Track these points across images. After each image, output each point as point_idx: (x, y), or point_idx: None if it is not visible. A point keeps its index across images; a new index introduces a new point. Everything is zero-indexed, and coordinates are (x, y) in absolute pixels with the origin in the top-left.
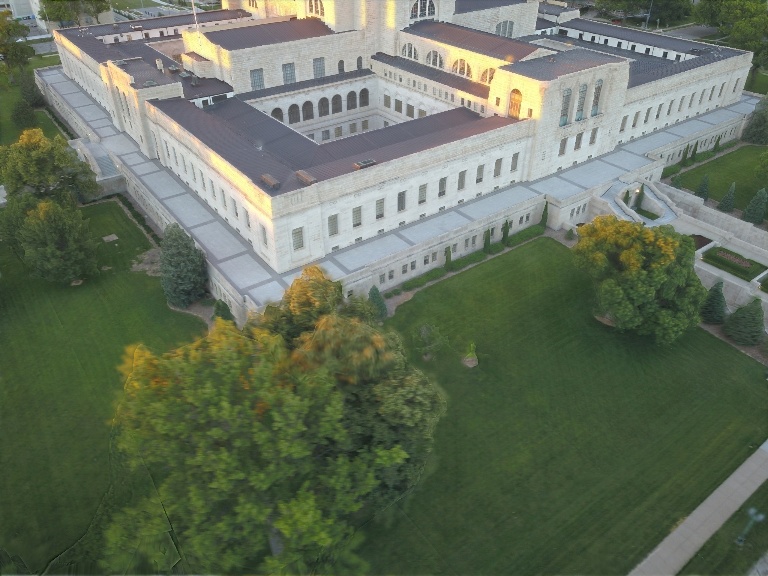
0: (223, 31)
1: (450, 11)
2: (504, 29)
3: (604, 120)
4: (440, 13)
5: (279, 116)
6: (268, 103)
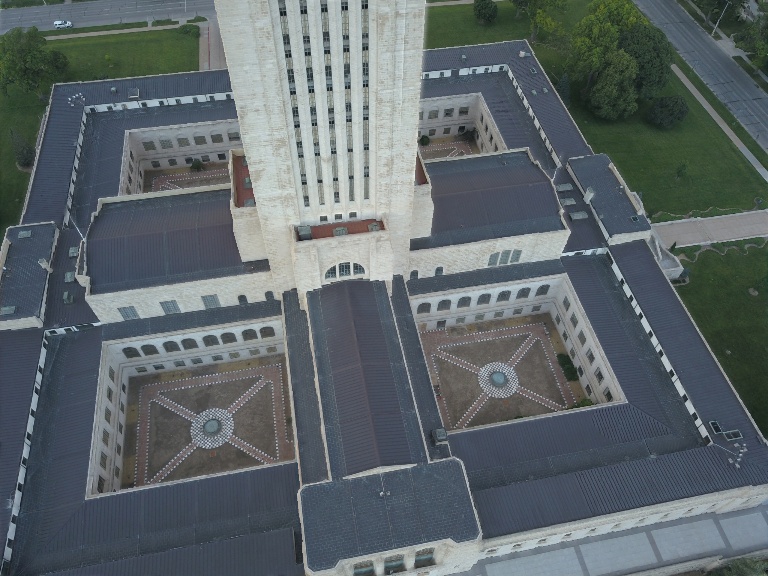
0: (115, 238)
1: (388, 271)
2: (506, 255)
3: (439, 568)
4: (371, 274)
5: (152, 348)
6: (134, 342)
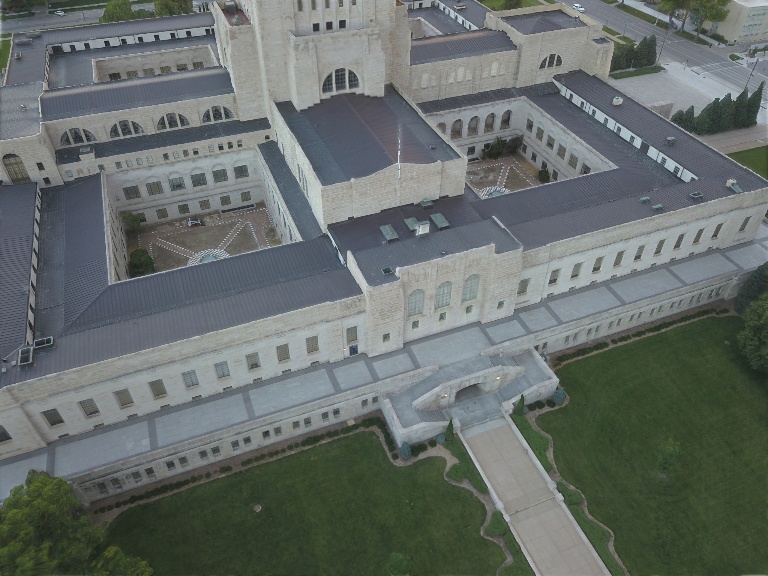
0: None
1: None
2: None
3: None
4: None
5: None
6: None
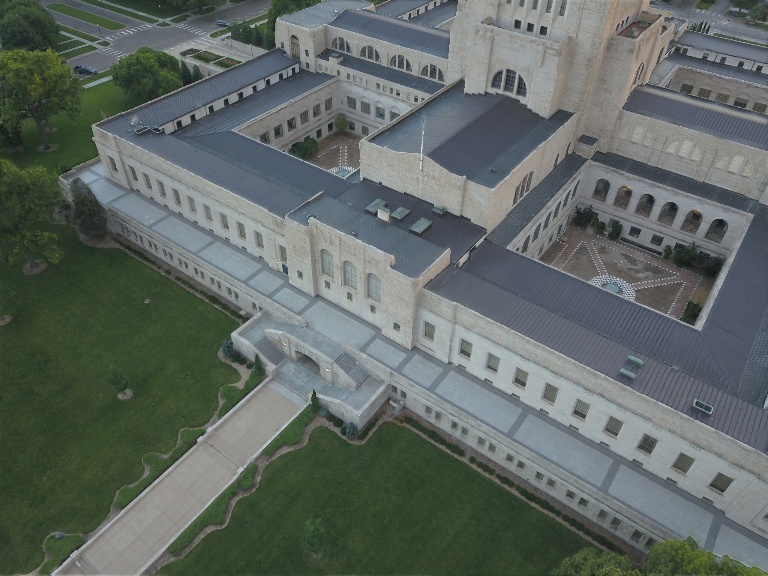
0: None
1: None
2: None
3: None
4: None
5: None
6: None
